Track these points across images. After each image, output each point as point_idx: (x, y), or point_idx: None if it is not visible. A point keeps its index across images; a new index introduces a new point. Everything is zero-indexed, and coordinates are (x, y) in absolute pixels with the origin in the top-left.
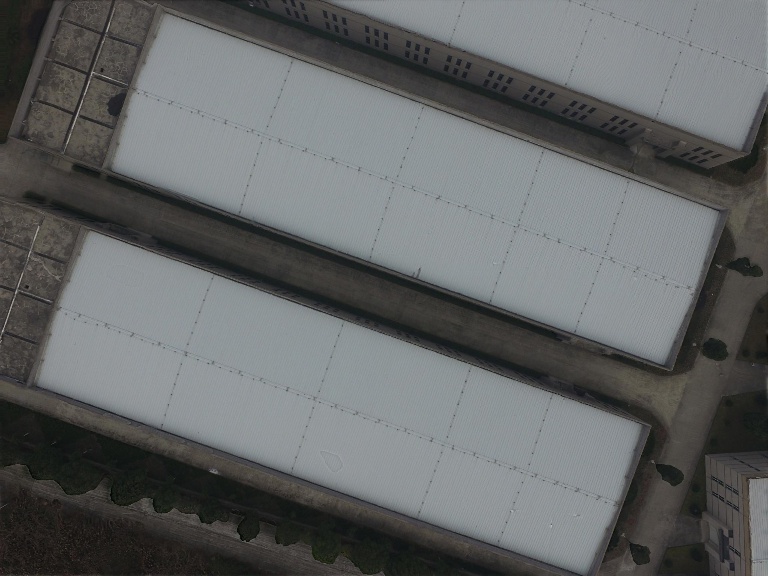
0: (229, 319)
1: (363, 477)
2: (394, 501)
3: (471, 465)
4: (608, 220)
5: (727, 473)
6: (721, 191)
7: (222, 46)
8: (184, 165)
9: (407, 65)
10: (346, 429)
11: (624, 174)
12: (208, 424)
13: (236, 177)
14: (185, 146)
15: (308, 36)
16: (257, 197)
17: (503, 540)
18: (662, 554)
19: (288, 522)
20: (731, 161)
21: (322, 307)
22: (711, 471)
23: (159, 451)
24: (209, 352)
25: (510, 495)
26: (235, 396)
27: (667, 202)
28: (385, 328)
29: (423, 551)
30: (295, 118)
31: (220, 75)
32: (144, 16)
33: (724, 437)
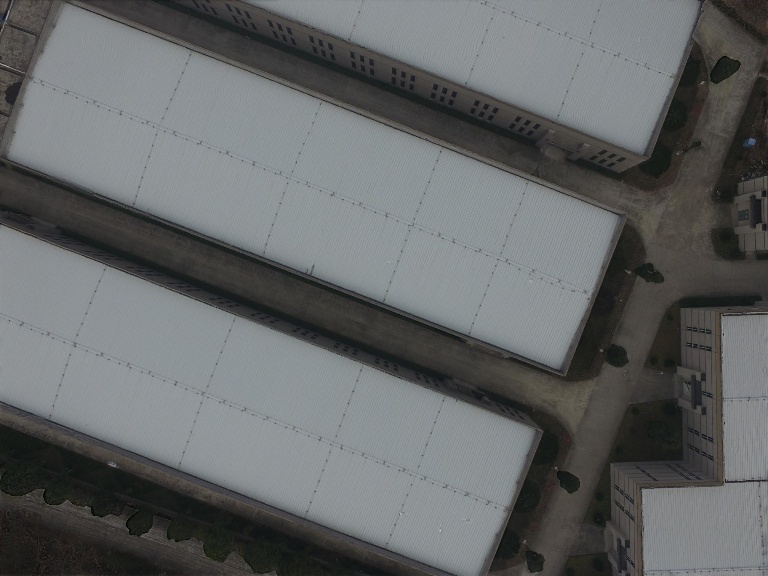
0: (120, 311)
1: (251, 474)
2: (282, 500)
3: (360, 465)
4: (505, 221)
5: (626, 482)
6: (633, 196)
7: (117, 36)
8: (80, 155)
9: (317, 61)
10: (234, 425)
11: (522, 175)
12: (96, 416)
13: (131, 168)
14: (81, 136)
15: (219, 29)
16: (152, 189)
17: (392, 543)
18: (564, 563)
19: (181, 518)
20: (643, 165)
21: (217, 302)
22: (614, 480)
23: (58, 442)
24: (98, 343)
25: (399, 497)
26: (123, 389)
27: (566, 205)
28: (283, 325)
29: (321, 552)
30: (191, 111)
31: (117, 66)
32: (44, 5)
33: (630, 445)
